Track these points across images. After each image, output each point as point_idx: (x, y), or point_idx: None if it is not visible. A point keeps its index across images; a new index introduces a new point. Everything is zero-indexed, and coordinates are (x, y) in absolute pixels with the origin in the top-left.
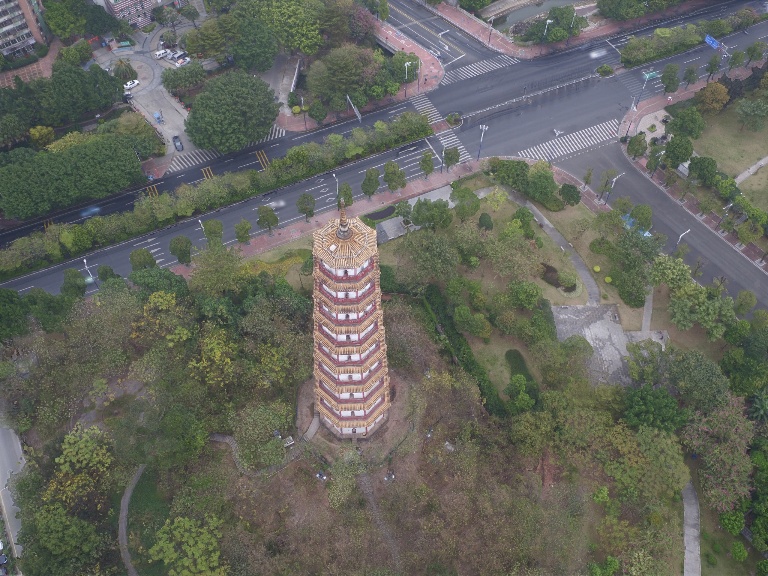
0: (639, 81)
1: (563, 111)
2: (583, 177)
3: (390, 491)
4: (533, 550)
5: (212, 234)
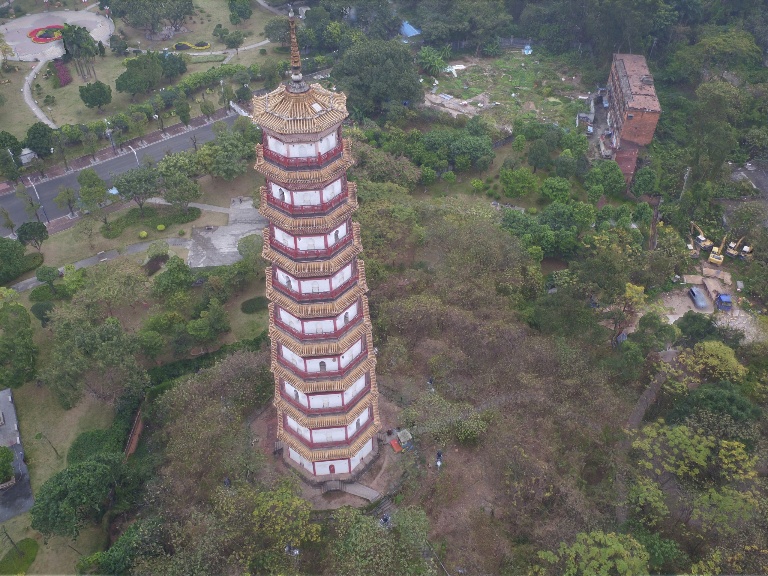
0: None
1: None
2: None
3: None
4: (497, 255)
5: None
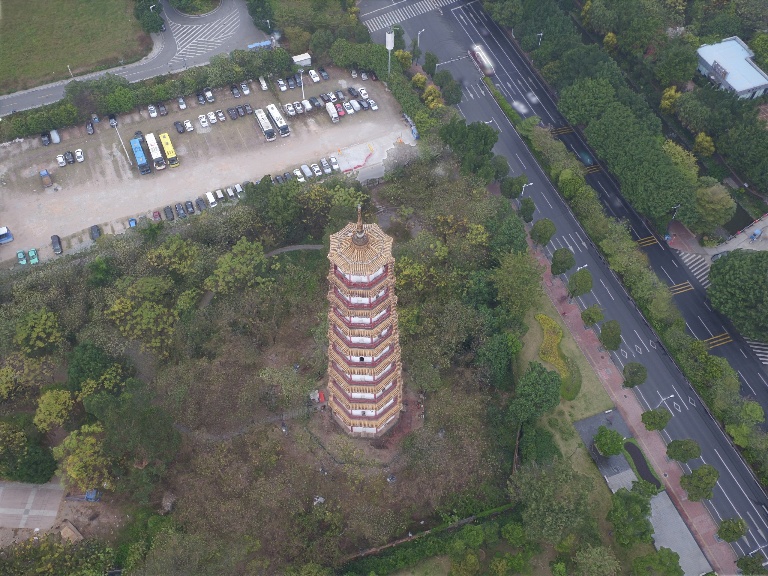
0: None
1: None
2: None
3: None
4: None
5: (574, 280)
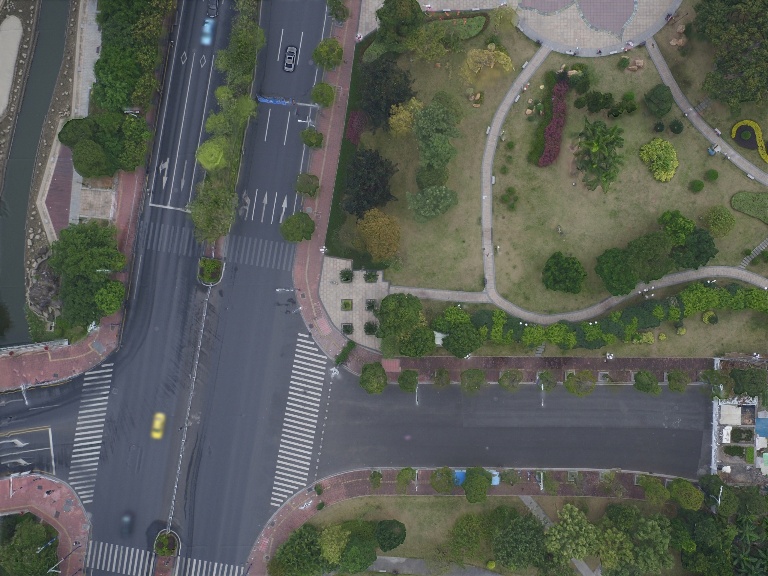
0: (256, 238)
1: (242, 390)
2: (369, 479)
3: None
4: None
5: None
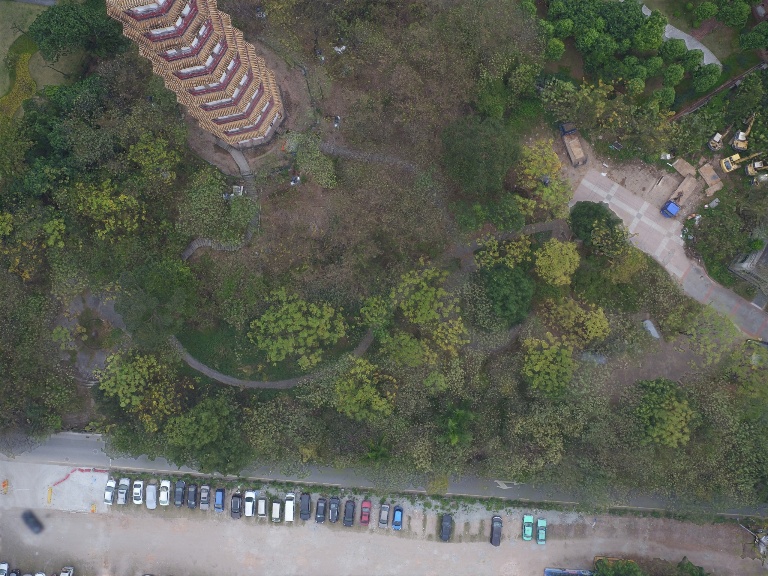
0: None
1: None
2: None
3: (346, 130)
4: (486, 42)
5: None
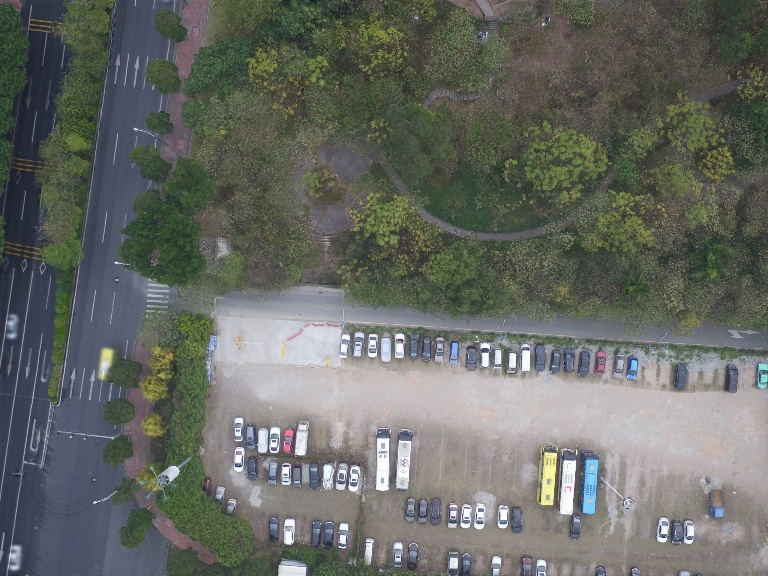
0: None
1: None
2: None
3: None
4: None
5: None
